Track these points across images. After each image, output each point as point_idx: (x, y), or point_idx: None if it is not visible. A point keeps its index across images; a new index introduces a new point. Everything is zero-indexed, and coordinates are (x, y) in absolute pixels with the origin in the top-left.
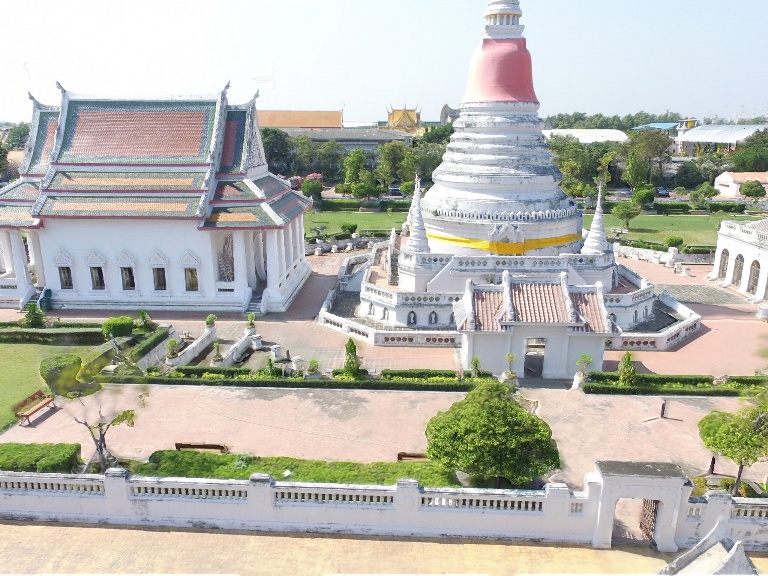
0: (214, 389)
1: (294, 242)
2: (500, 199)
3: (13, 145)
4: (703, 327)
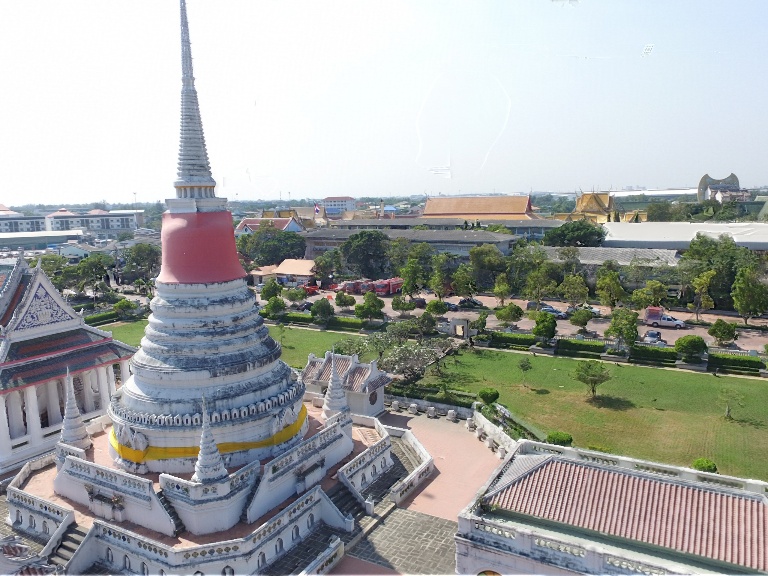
0: None
1: (100, 393)
2: (141, 394)
3: None
4: None
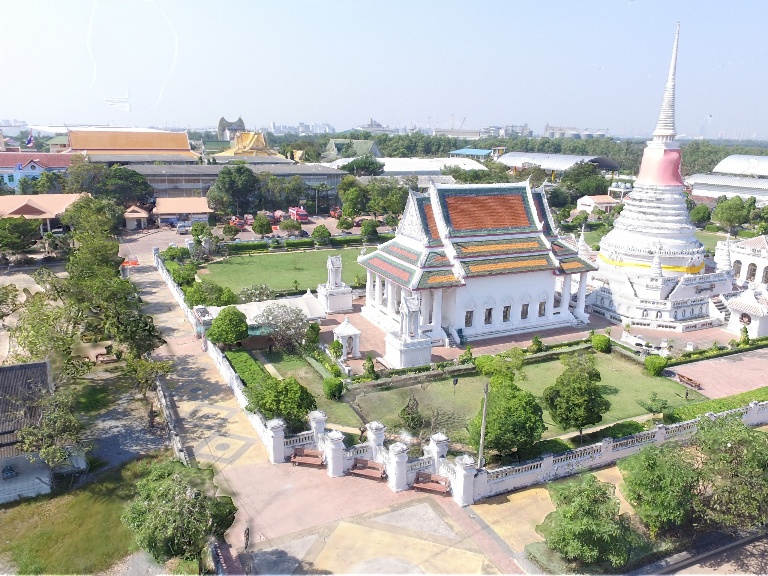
0: (712, 361)
1: None
2: (685, 242)
3: None
4: None
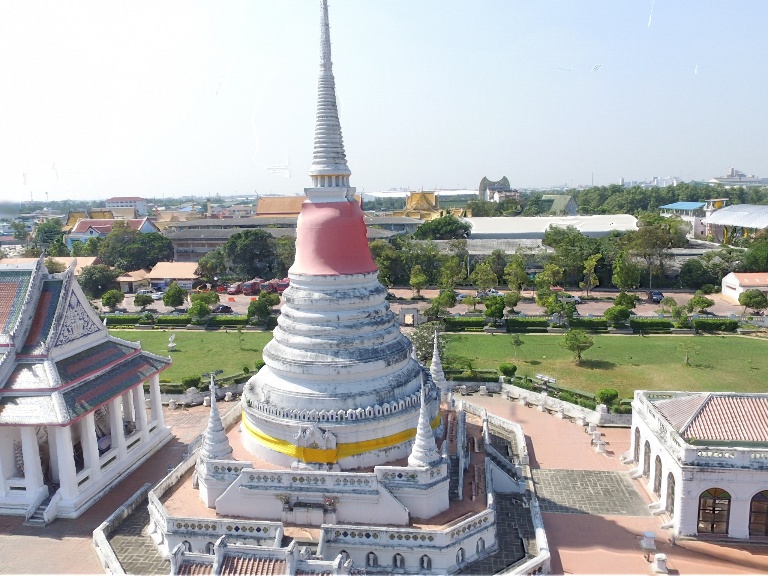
0: None
1: (137, 412)
2: (313, 392)
3: (9, 251)
4: (556, 568)
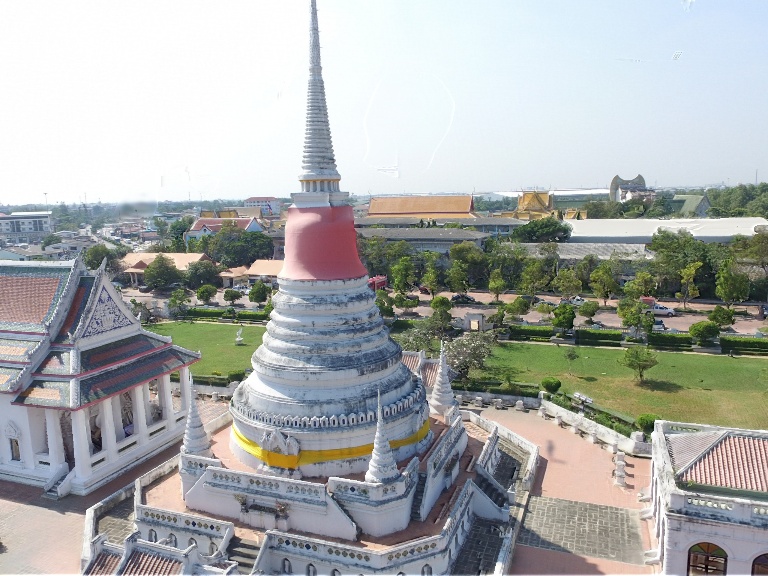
0: None
1: (164, 402)
2: (283, 397)
3: (135, 247)
4: None
